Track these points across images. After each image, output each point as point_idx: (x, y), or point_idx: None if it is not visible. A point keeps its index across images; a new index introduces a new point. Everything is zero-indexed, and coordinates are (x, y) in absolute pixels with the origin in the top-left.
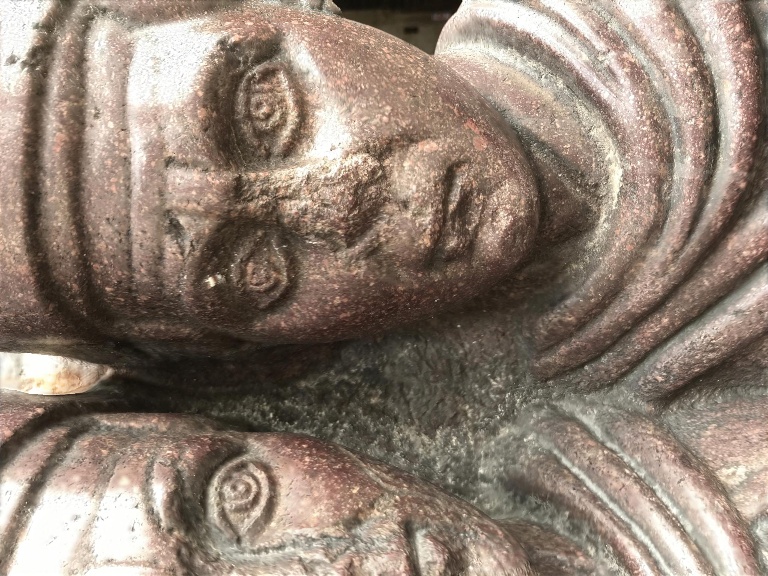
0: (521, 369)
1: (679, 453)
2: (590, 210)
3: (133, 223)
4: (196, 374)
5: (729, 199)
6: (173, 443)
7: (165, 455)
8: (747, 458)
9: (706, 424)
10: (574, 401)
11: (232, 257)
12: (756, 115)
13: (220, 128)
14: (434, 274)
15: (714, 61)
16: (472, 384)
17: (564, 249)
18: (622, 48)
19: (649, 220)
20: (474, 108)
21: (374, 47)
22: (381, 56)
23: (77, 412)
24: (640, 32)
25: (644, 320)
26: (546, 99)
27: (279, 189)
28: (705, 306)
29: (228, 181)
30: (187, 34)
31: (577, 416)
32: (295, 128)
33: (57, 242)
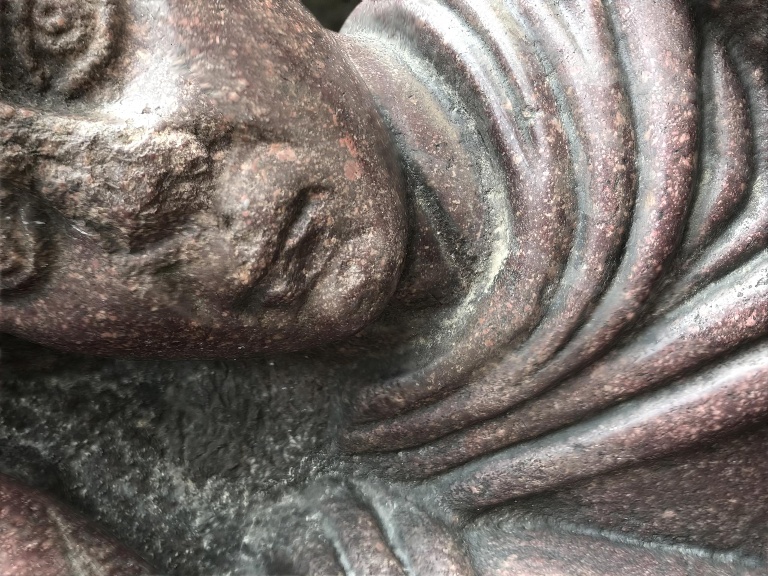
0: (328, 433)
1: None
2: (459, 283)
3: None
4: None
5: (611, 326)
6: None
7: None
8: None
9: (507, 552)
10: (376, 486)
11: None
12: (669, 243)
13: None
14: (244, 317)
15: (646, 166)
16: (267, 436)
17: (417, 318)
18: (553, 112)
19: (520, 320)
20: (360, 122)
21: None
22: (259, 8)
23: None
24: (579, 101)
25: (478, 424)
26: (450, 137)
27: (44, 142)
28: (546, 428)
29: None
30: None
31: (374, 504)
32: (98, 62)
33: None
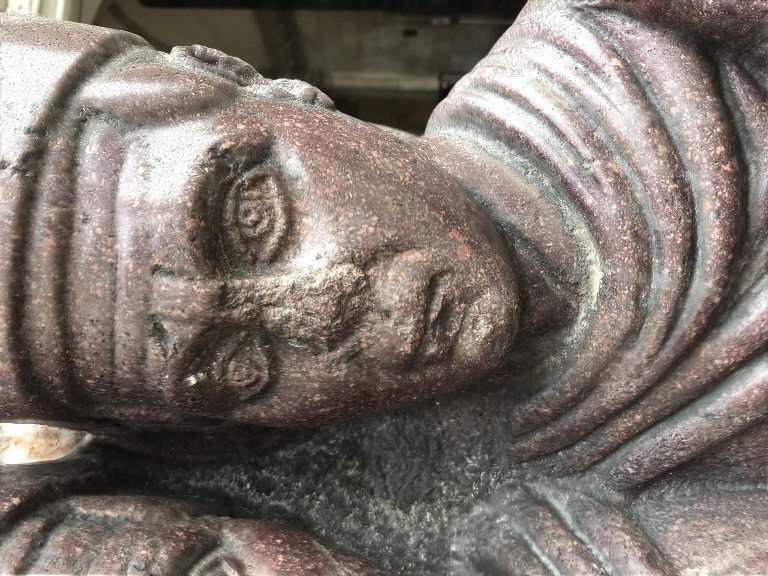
0: (497, 449)
1: (646, 550)
2: (570, 306)
3: (117, 325)
4: (175, 443)
5: (704, 312)
6: (148, 540)
7: (139, 556)
8: (711, 559)
9: (674, 518)
10: (547, 484)
11: (214, 356)
12: (733, 235)
13: (207, 237)
14: (414, 376)
15: (694, 179)
16: (448, 461)
17: (543, 341)
18: (607, 158)
19: (626, 325)
20: (460, 214)
21: (364, 151)
22: (370, 161)
23: (53, 497)
24: (624, 145)
25: (618, 415)
26: (531, 196)
27: (264, 296)
28: (677, 406)
29: (213, 290)
30: (179, 140)
31: (549, 500)
32: (282, 235)
33: (40, 341)
